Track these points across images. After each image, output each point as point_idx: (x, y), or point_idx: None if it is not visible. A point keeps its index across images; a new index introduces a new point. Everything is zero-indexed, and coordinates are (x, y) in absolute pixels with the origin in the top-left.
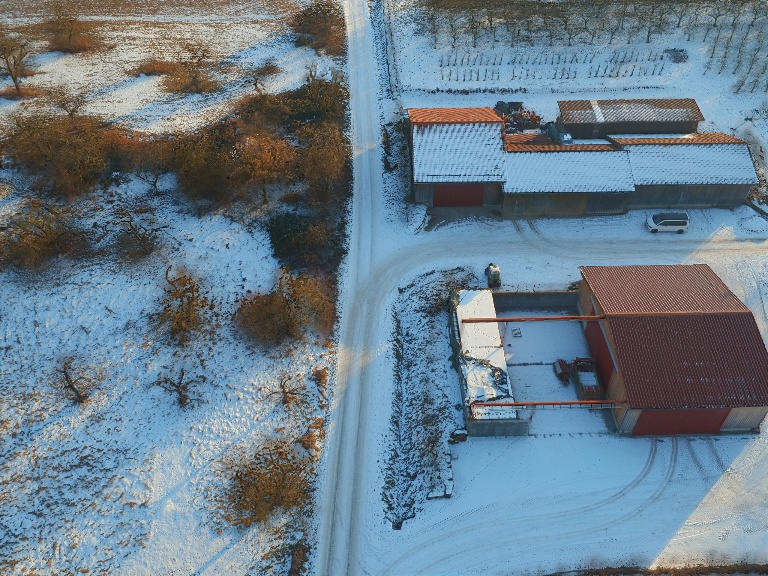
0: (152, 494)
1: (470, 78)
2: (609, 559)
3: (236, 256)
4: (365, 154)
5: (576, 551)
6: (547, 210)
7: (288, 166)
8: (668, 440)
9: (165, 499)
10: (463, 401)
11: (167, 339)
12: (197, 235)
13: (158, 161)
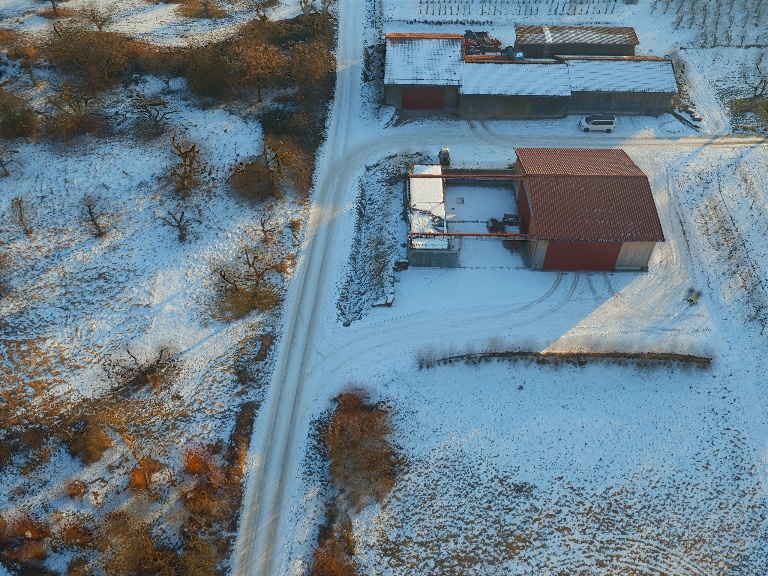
0: (155, 299)
1: (445, 12)
2: (510, 347)
3: (232, 138)
4: (348, 69)
5: (485, 342)
6: (498, 113)
7: (280, 73)
8: (572, 274)
9: (165, 302)
10: (407, 240)
11: (172, 195)
12: (201, 123)
13: (171, 67)
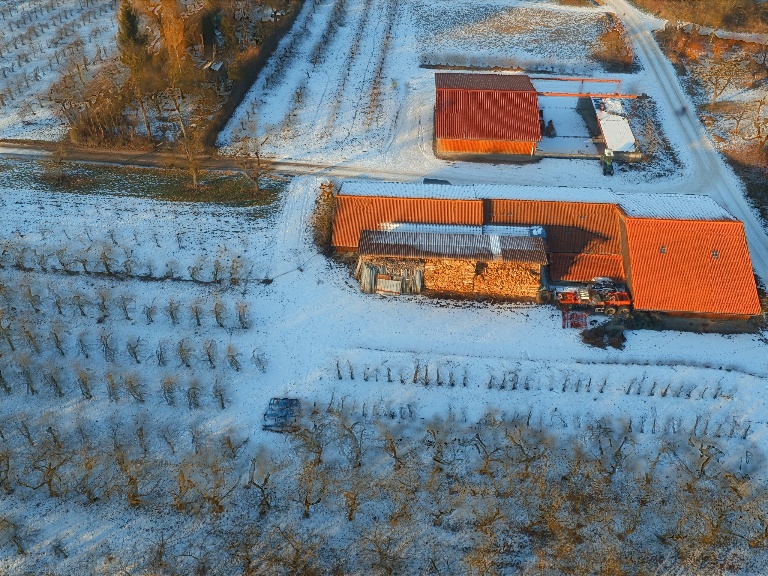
0: None
1: None
2: None
3: None
4: None
5: None
6: None
7: None
8: None
9: None
10: None
11: None
12: None
13: None
